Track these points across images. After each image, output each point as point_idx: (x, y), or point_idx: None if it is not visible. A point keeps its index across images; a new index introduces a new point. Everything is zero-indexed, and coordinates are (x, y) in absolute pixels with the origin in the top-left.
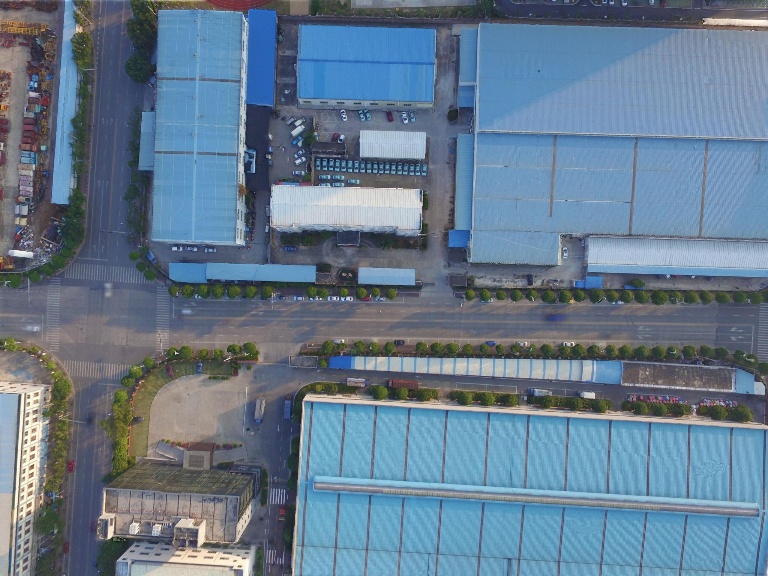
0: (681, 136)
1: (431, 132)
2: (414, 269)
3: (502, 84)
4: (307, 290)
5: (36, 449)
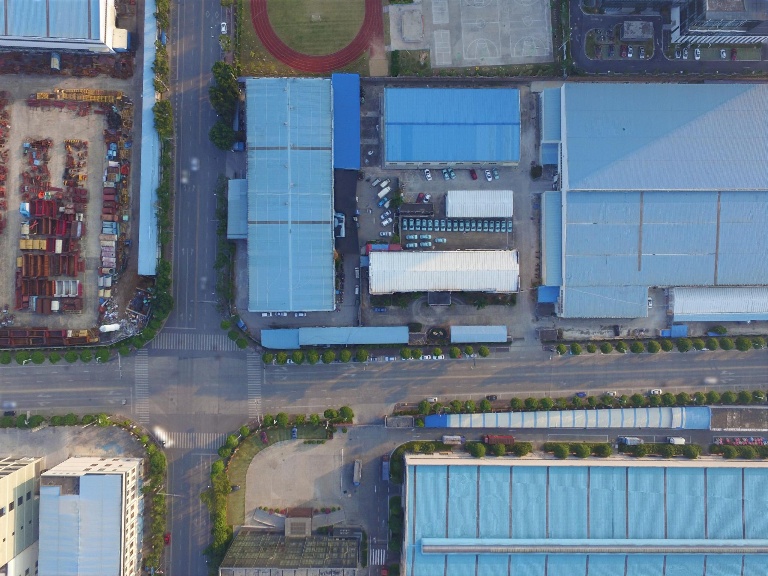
0: (762, 189)
1: (514, 188)
2: (505, 326)
3: (589, 143)
4: (402, 352)
5: (134, 526)
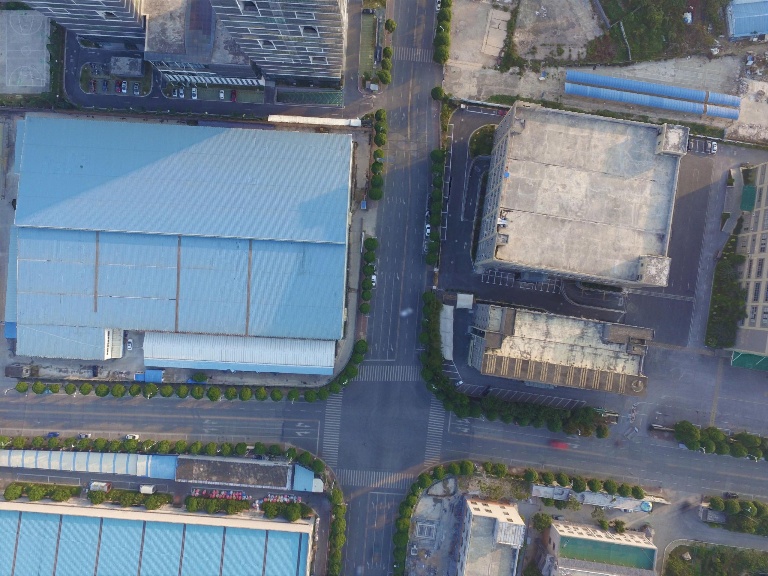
0: (221, 236)
1: (0, 219)
2: None
3: (43, 179)
4: None
5: None
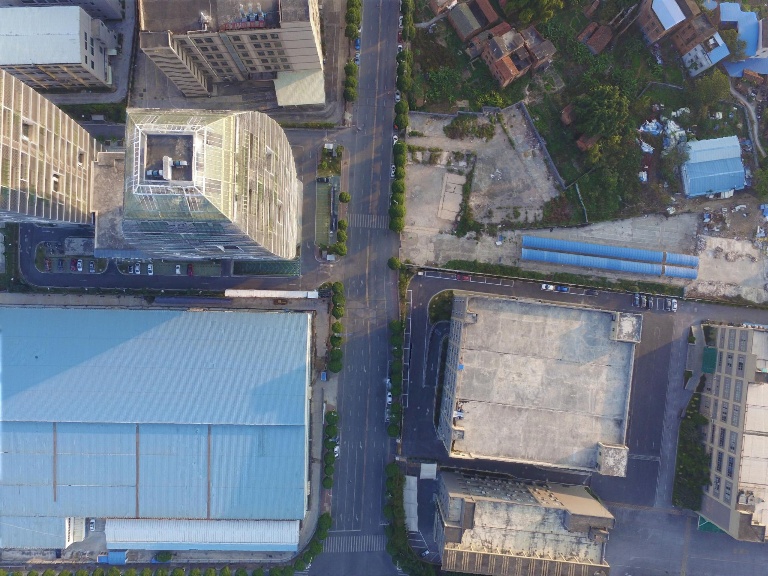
0: None
1: None
2: None
3: None
4: None
5: None
